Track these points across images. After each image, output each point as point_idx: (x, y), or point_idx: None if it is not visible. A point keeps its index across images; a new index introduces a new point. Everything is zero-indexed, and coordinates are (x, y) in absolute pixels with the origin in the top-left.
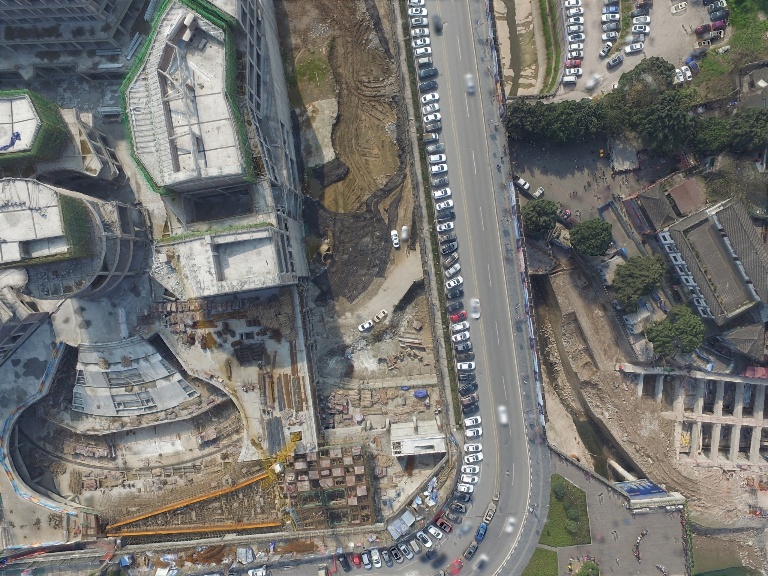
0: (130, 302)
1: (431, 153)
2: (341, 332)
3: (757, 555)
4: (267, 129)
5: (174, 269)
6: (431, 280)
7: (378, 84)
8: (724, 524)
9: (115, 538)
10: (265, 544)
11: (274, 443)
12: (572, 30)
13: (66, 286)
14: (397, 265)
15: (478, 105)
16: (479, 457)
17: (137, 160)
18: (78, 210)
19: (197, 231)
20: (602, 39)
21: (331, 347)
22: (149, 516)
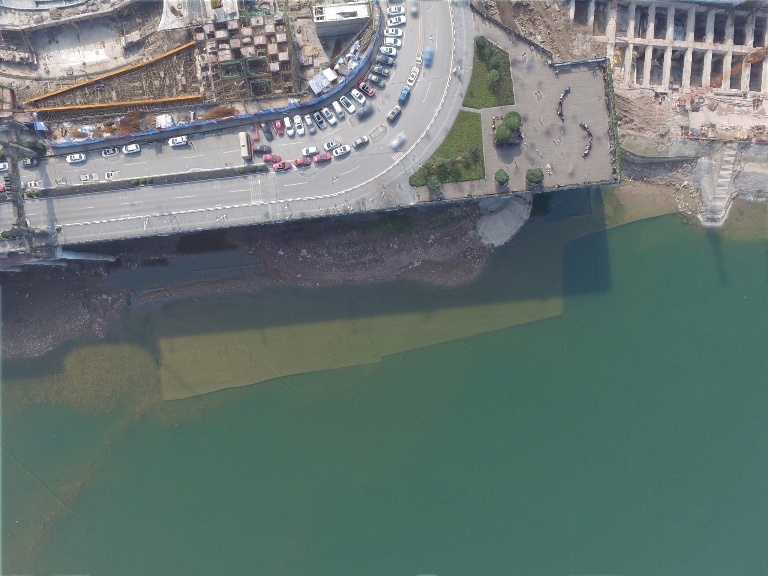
0: None
1: None
2: None
3: (692, 196)
4: None
5: None
6: None
7: None
8: (657, 151)
9: (32, 112)
10: (186, 113)
11: (194, 9)
12: None
13: None
14: None
15: None
16: (402, 19)
17: None
18: None
19: None
20: None
21: None
22: (67, 90)
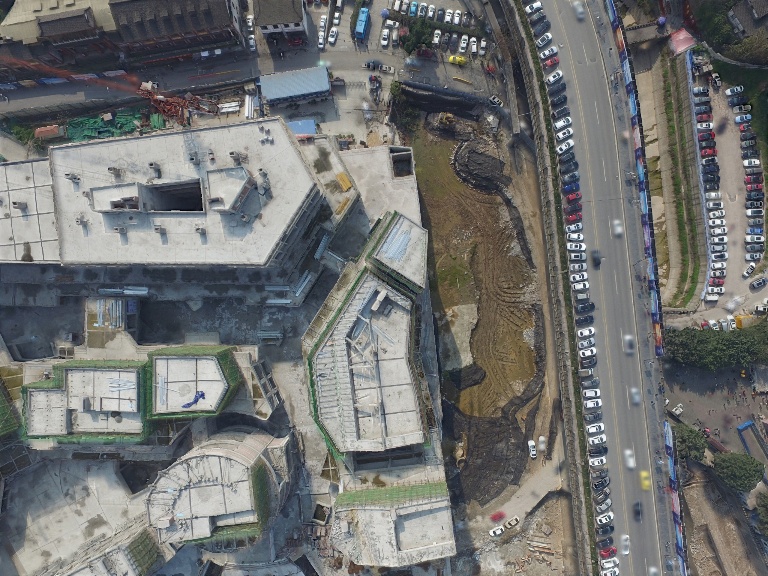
0: (278, 523)
1: (586, 387)
2: (473, 537)
3: None
4: (424, 359)
5: (352, 534)
6: (581, 514)
7: (518, 290)
8: None
9: None
10: None
11: None
12: (716, 250)
13: (239, 540)
14: (532, 474)
15: (633, 340)
16: None
17: (320, 425)
18: (262, 476)
19: (365, 479)
20: (745, 259)
21: (461, 550)
22: None
